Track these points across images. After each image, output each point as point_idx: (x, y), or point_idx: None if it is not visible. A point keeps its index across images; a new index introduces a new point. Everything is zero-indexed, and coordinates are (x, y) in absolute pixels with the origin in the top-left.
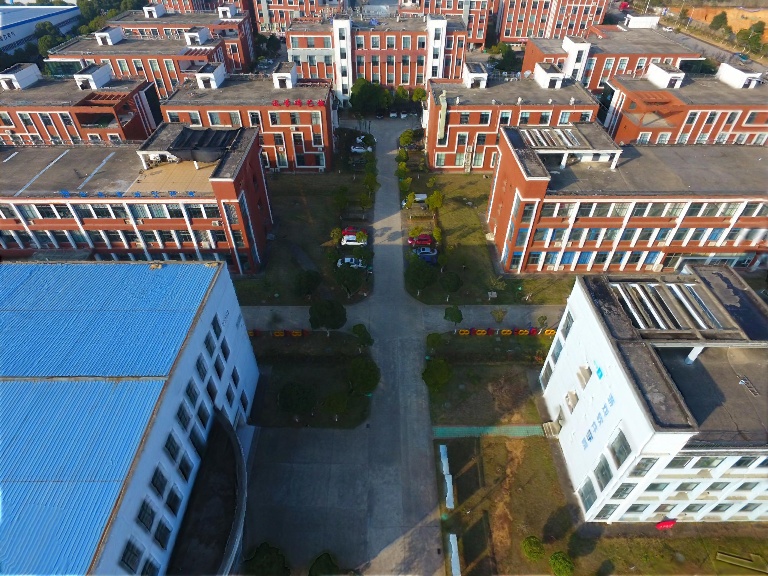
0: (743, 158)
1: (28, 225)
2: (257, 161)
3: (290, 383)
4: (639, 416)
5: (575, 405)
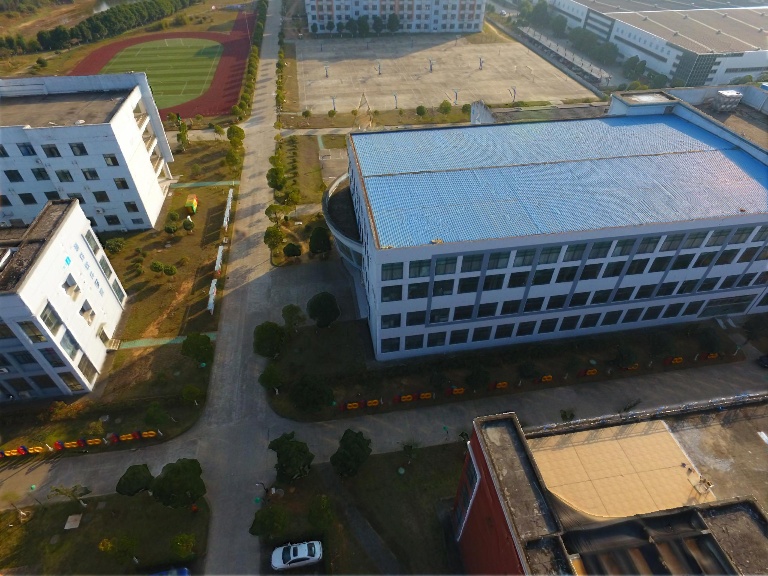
0: None
1: None
2: None
3: (327, 301)
4: None
5: None
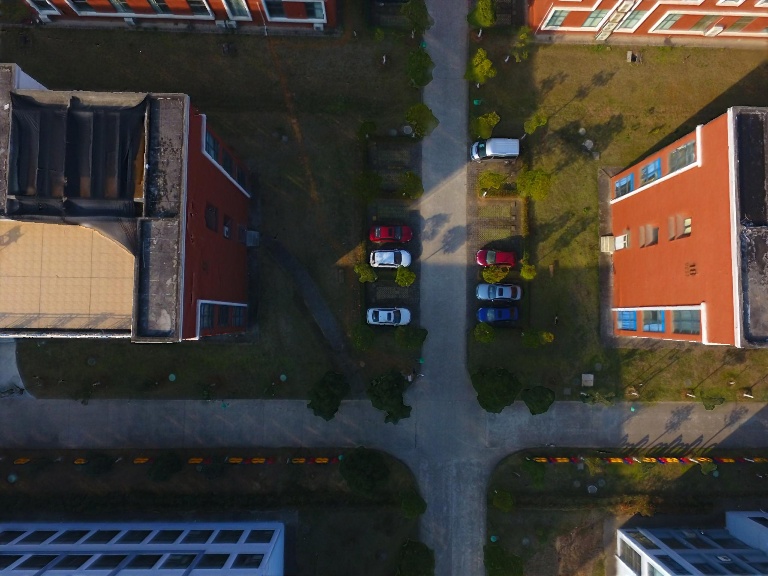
0: None
1: None
2: (203, 166)
3: None
4: None
5: None
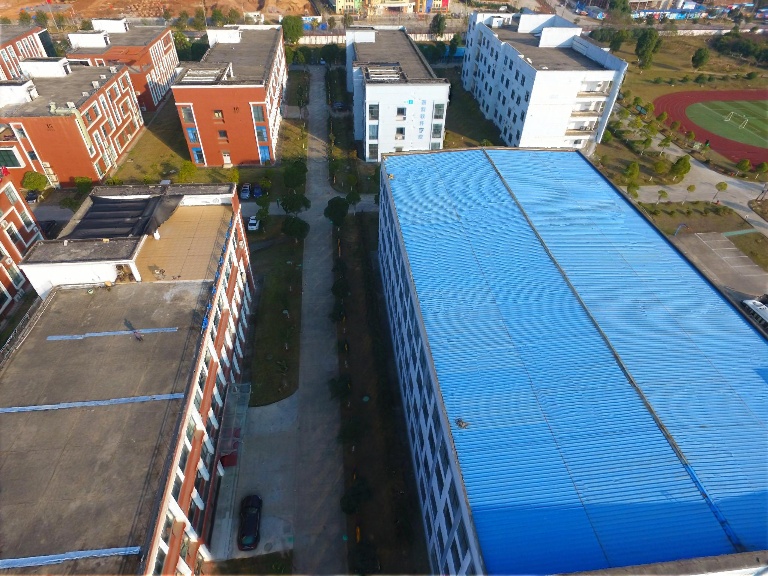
0: (230, 51)
1: (203, 424)
2: None
3: None
4: (441, 88)
5: (403, 134)
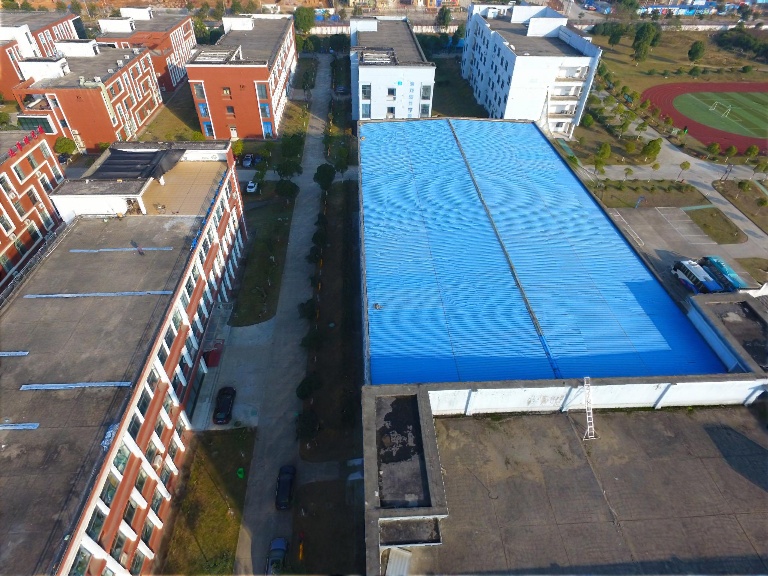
0: (242, 37)
1: None
2: None
3: None
4: (428, 71)
5: (393, 114)
